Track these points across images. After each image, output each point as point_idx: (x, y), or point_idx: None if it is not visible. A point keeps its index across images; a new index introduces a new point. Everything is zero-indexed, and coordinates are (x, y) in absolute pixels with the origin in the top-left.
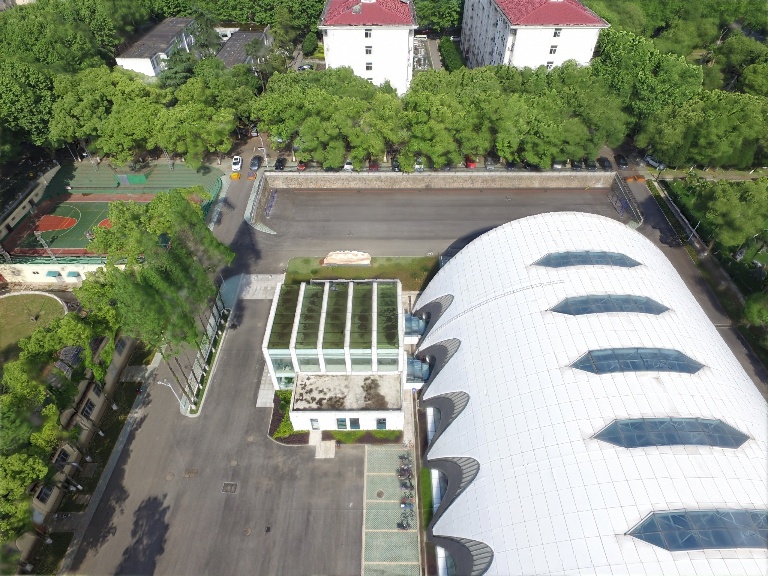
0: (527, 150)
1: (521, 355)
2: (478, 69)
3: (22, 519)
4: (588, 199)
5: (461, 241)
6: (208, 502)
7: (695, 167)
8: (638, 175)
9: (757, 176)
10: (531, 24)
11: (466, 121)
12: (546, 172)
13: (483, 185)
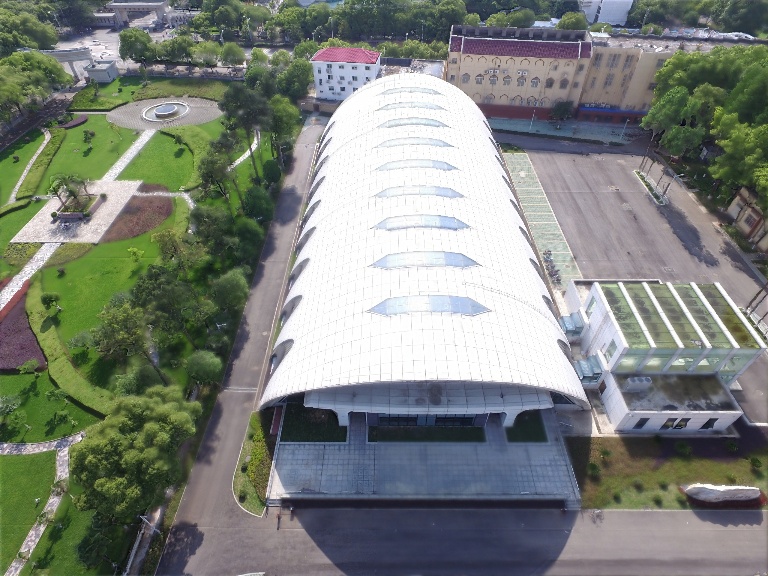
0: None
1: (501, 250)
2: None
3: (759, 185)
4: None
5: (550, 553)
6: (677, 263)
7: None
8: None
9: None
10: None
11: None
12: None
13: None
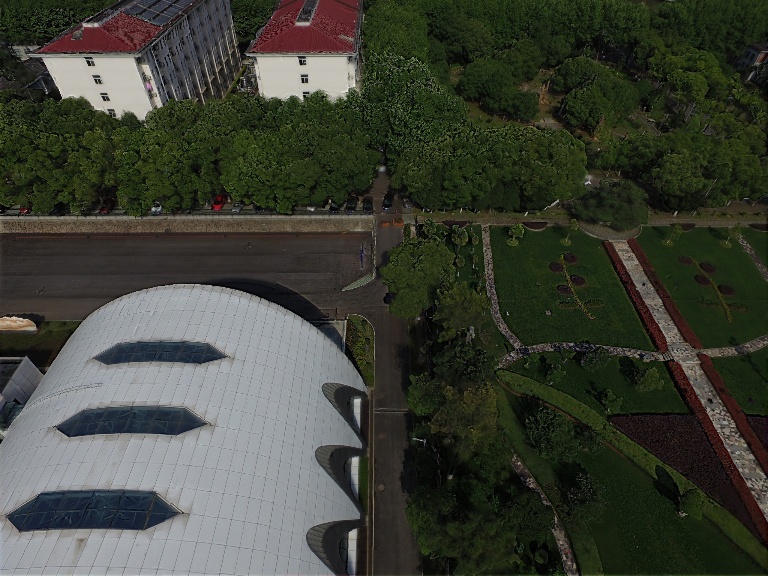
0: (254, 194)
1: None
2: (217, 101)
3: None
4: (338, 246)
5: None
6: None
7: (467, 208)
8: (396, 219)
9: (531, 219)
10: (269, 51)
11: (182, 162)
12: (295, 215)
13: (229, 229)
